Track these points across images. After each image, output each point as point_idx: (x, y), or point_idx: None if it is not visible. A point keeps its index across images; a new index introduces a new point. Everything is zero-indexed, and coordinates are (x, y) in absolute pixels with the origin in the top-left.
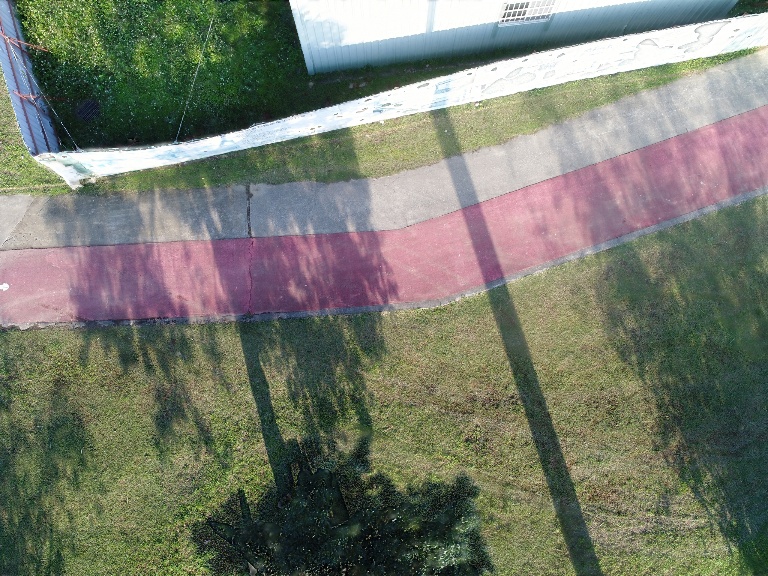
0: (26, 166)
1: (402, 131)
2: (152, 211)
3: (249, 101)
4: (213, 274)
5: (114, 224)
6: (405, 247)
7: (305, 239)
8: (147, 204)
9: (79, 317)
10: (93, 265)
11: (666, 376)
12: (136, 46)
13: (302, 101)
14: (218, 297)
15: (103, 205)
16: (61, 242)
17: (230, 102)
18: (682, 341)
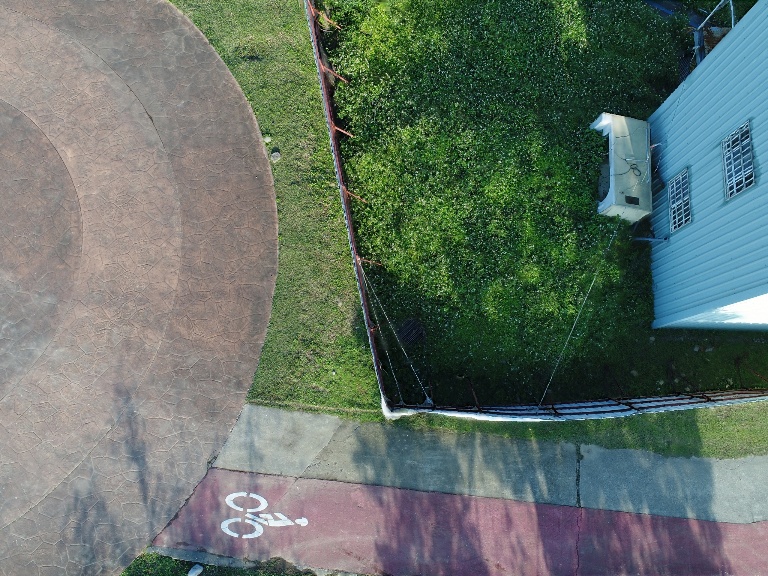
0: (336, 383)
1: (750, 409)
2: (472, 458)
3: (590, 352)
4: (536, 544)
5: (429, 467)
6: (751, 546)
7: (639, 518)
8: (466, 449)
9: (384, 572)
10: (403, 512)
11: None
12: (489, 284)
13: (642, 357)
14: (540, 572)
15: (418, 442)
16: (369, 478)
17: (575, 354)
18: None
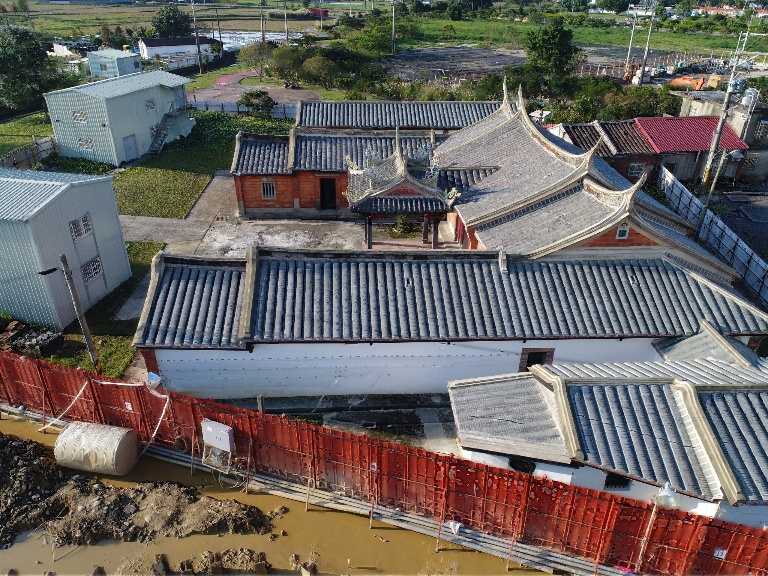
0: None
1: None
2: None
3: None
4: None
5: None
6: None
7: None
8: None
9: None
10: None
11: (1, 144)
12: None
13: None
14: None
15: None
16: None
17: None
18: (4, 146)
